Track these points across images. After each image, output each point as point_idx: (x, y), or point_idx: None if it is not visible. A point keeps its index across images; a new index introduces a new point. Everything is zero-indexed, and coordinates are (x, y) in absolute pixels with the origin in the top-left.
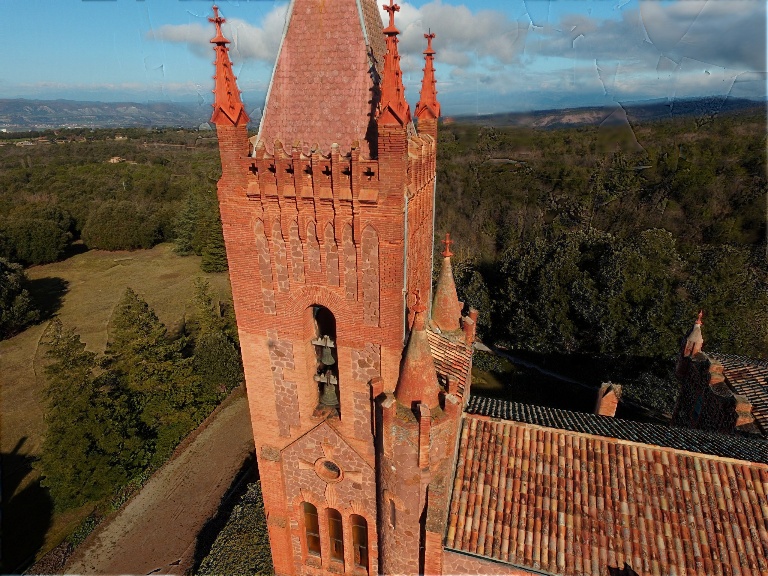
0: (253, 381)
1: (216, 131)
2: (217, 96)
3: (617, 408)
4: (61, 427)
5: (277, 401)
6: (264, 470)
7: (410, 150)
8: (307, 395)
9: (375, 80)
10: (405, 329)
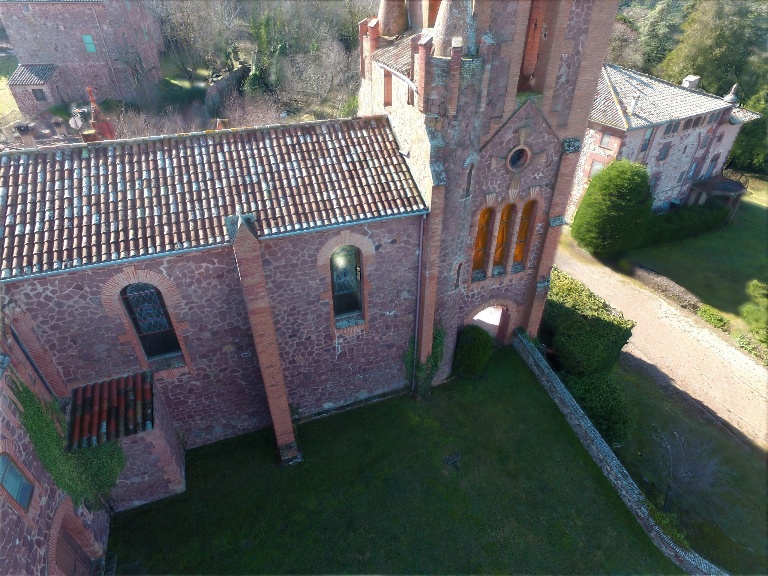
0: None
1: None
2: None
3: None
4: None
5: None
6: None
7: None
8: None
9: None
10: None
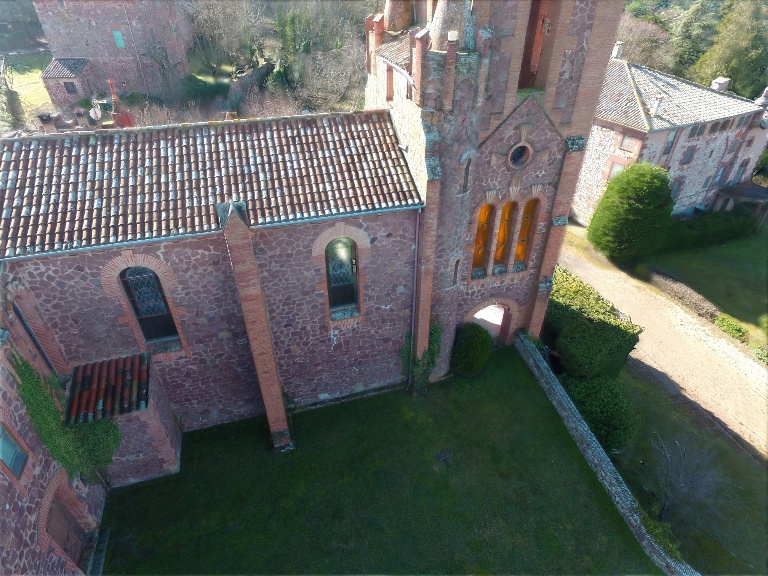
0: None
1: None
2: None
3: None
4: None
5: None
6: None
7: None
8: None
9: None
10: None
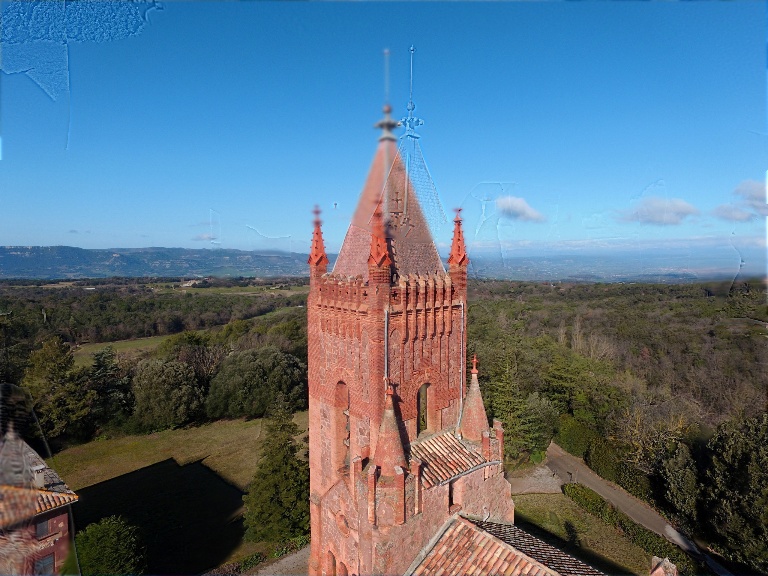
0: (312, 435)
1: None
2: (312, 249)
3: None
4: (263, 473)
5: (322, 454)
6: (311, 512)
7: (401, 282)
8: (335, 452)
9: (386, 240)
10: None
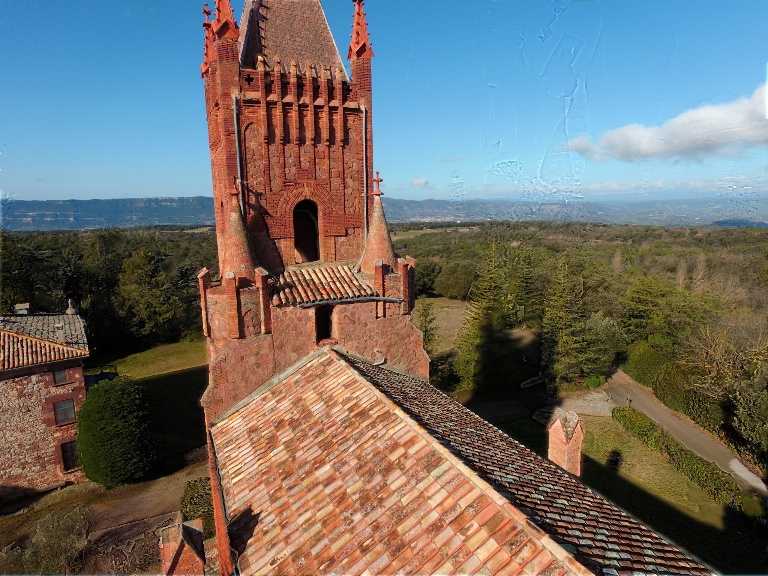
0: None
1: (549, 201)
2: None
3: None
4: None
5: None
6: None
7: (258, 64)
8: None
9: (251, 18)
10: (252, 224)
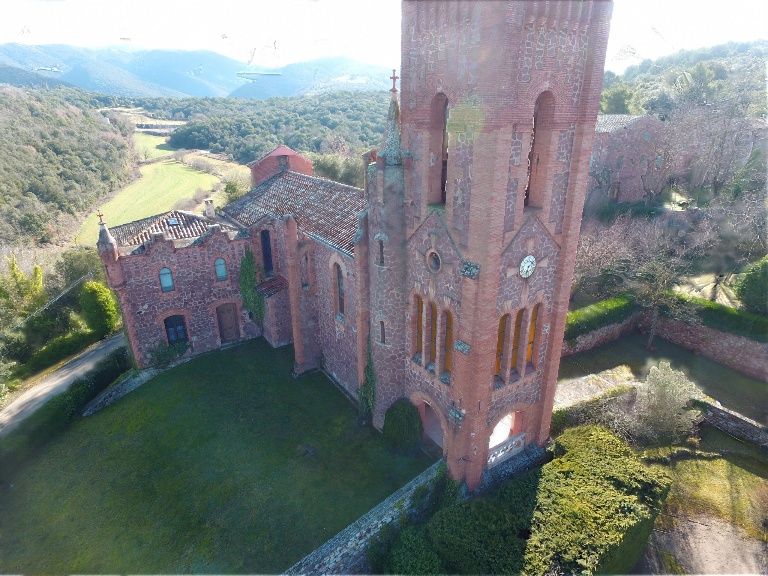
0: None
1: None
2: None
3: (27, 430)
4: None
5: None
6: None
7: None
8: None
9: None
10: None
